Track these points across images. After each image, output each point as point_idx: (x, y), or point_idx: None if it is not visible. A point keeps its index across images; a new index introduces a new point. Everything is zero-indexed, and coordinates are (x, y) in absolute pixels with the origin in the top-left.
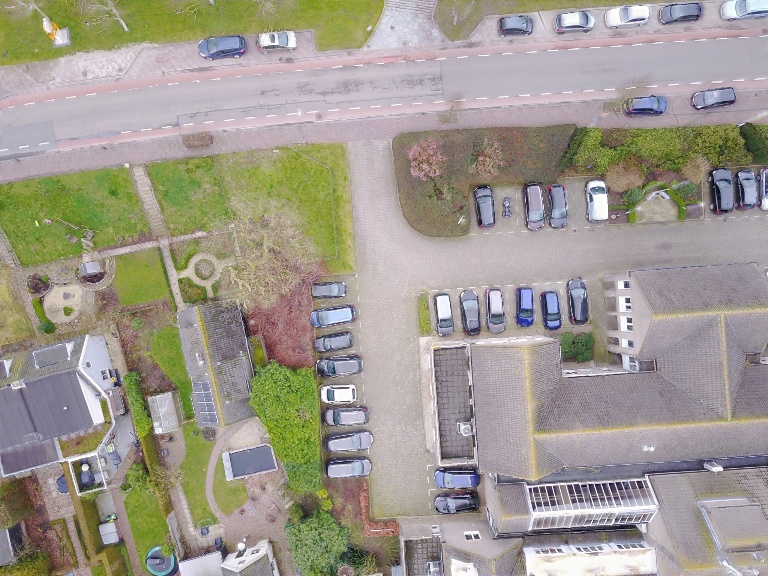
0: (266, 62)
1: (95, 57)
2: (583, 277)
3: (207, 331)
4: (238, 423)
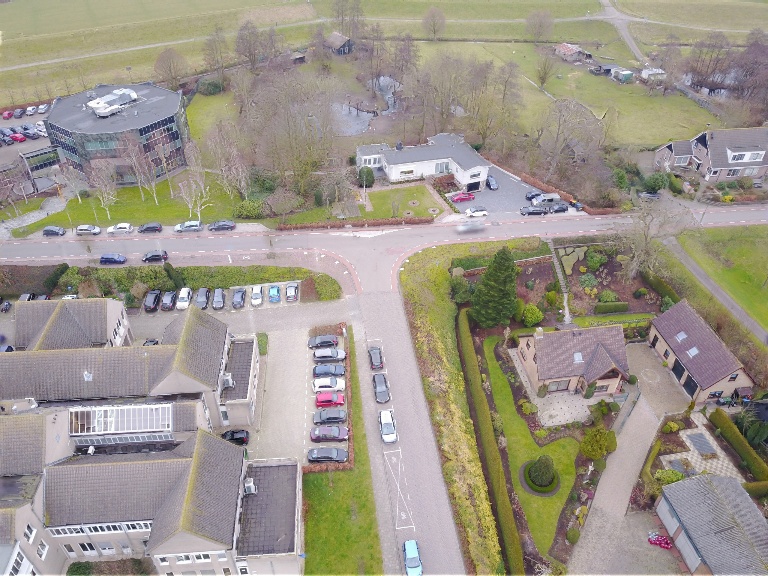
0: None
1: None
2: None
3: None
4: None
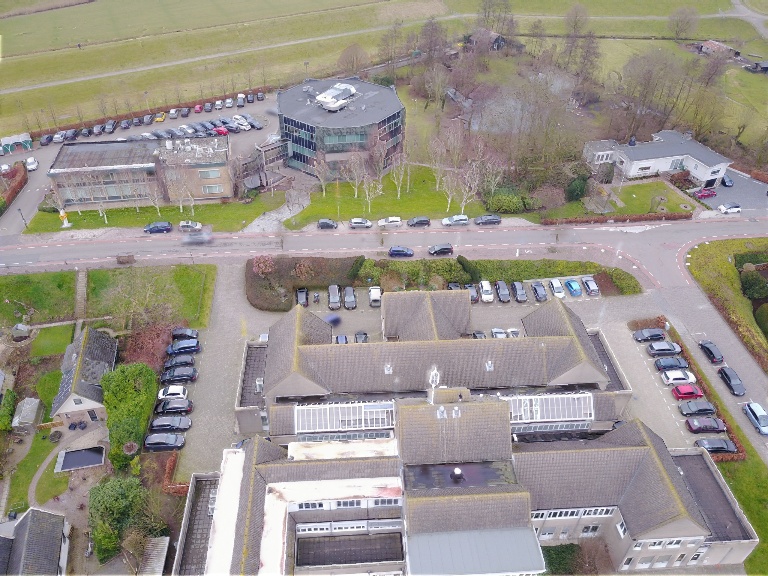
0: (181, 235)
1: (82, 232)
2: (367, 334)
3: (88, 340)
4: (84, 431)
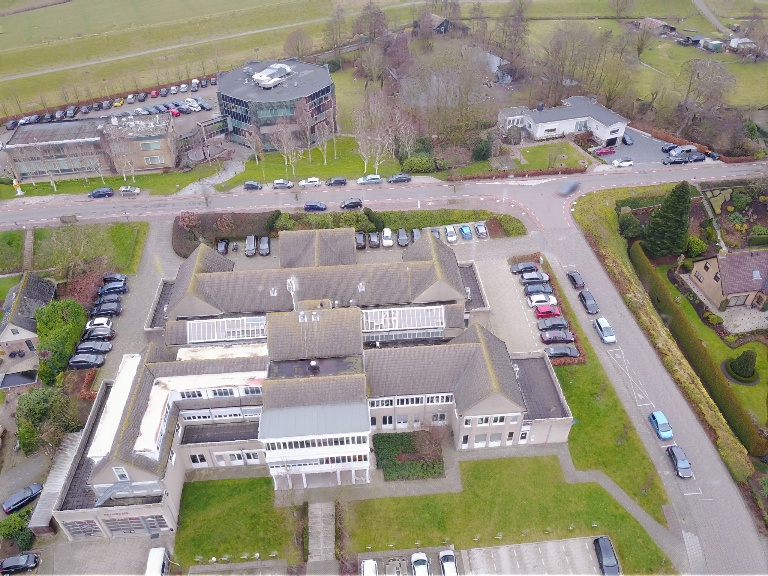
0: (121, 199)
1: (33, 198)
2: None
3: (27, 282)
4: (22, 358)
